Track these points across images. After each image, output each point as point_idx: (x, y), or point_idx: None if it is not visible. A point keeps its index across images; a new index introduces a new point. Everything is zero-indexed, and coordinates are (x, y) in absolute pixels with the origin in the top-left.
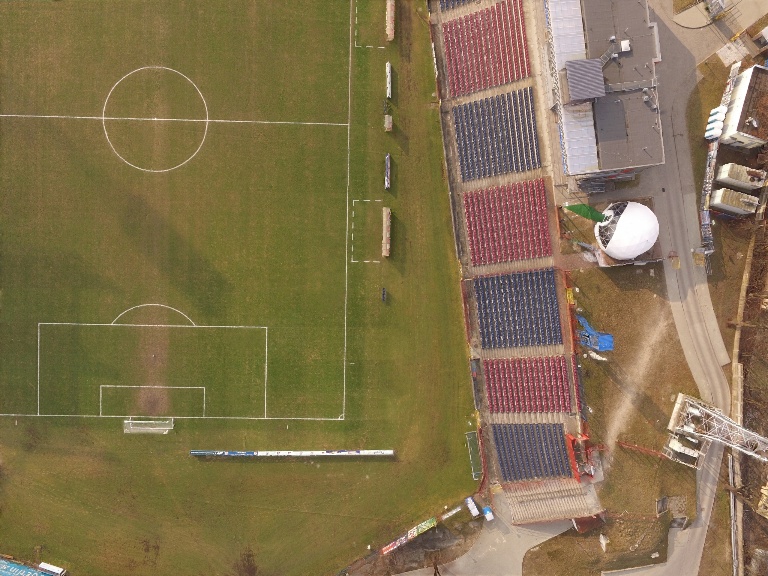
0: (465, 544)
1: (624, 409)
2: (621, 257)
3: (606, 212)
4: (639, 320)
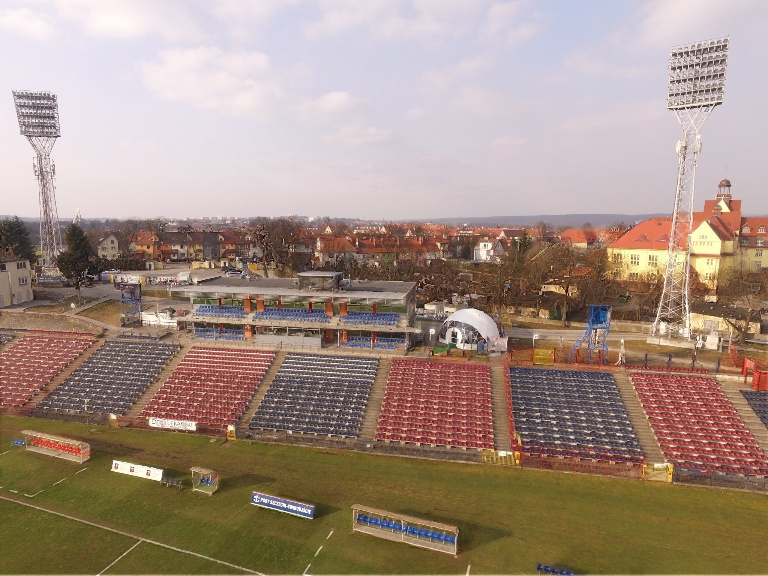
0: None
1: (685, 361)
2: None
3: (447, 339)
4: None
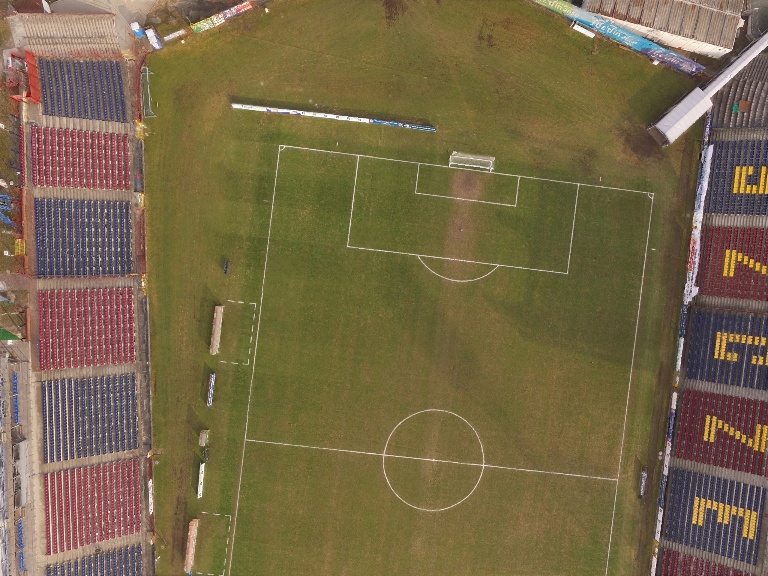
0: (167, 1)
1: None
2: None
3: None
4: None
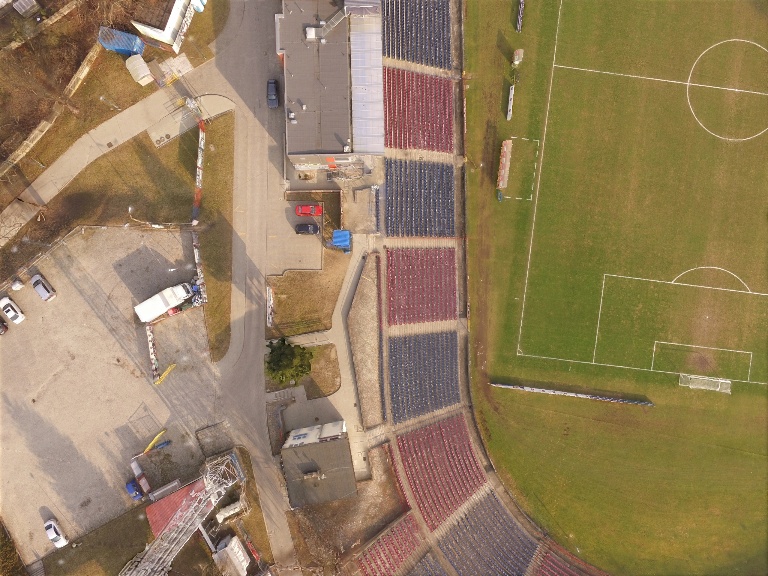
0: None
1: None
2: None
3: None
4: None
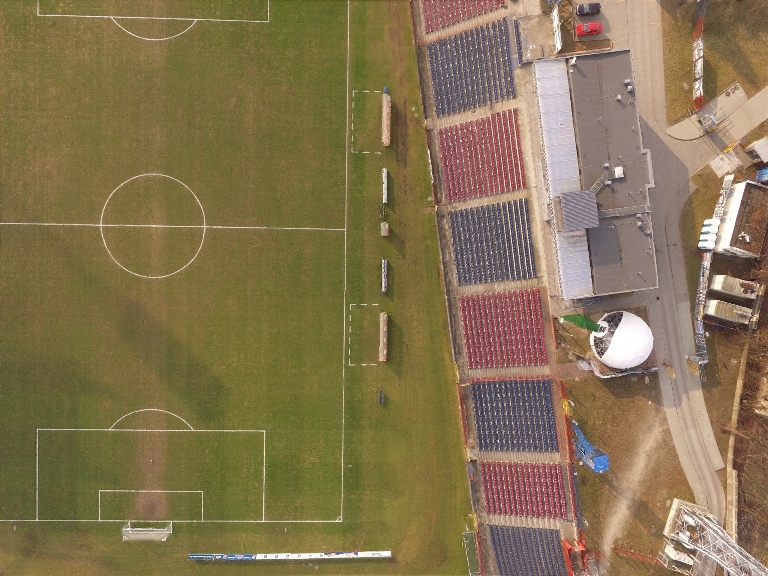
0: None
1: (620, 515)
2: (616, 367)
3: (601, 323)
4: (634, 427)
